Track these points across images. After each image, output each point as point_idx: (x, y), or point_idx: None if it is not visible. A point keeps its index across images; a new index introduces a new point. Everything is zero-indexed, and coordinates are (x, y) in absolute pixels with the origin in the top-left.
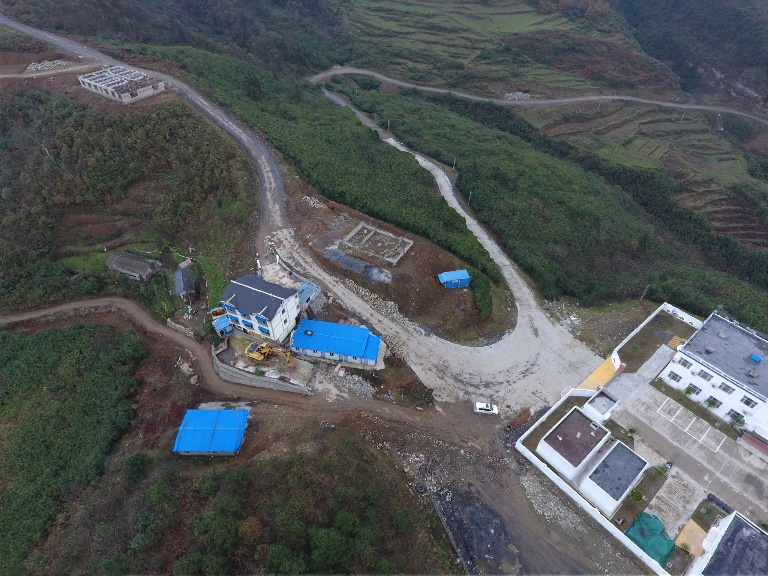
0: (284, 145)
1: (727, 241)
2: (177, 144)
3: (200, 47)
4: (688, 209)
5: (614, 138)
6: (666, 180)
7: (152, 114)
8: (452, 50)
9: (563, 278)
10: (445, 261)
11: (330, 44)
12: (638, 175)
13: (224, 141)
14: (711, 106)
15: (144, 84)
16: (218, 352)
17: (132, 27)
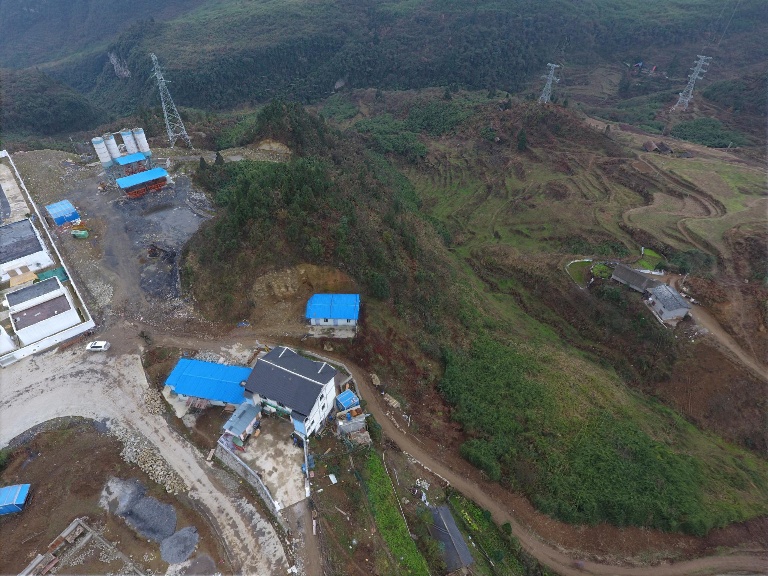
0: None
1: None
2: None
3: None
4: None
5: None
6: None
7: None
8: None
9: None
10: None
11: None
12: None
13: None
14: None
15: None
16: (349, 380)
17: None
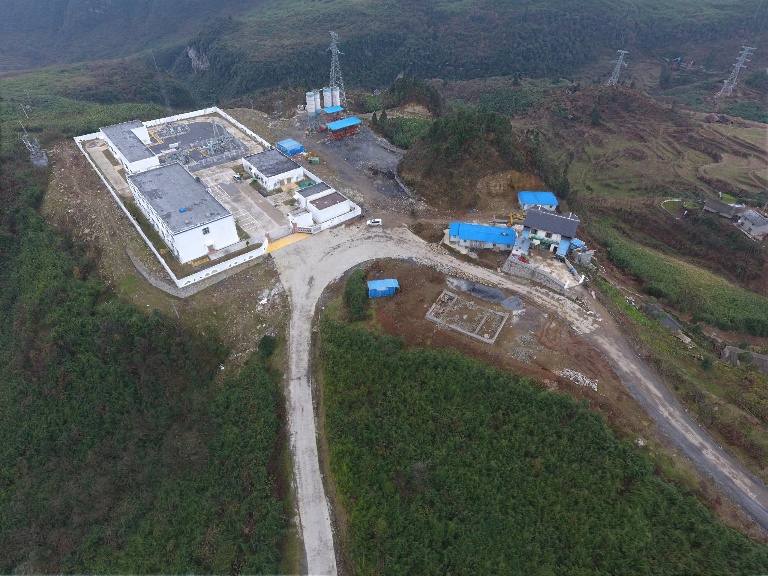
0: (746, 547)
1: None
2: None
3: None
4: None
5: None
6: None
7: None
8: None
9: None
10: None
11: None
12: None
13: None
14: None
15: None
16: None
17: None
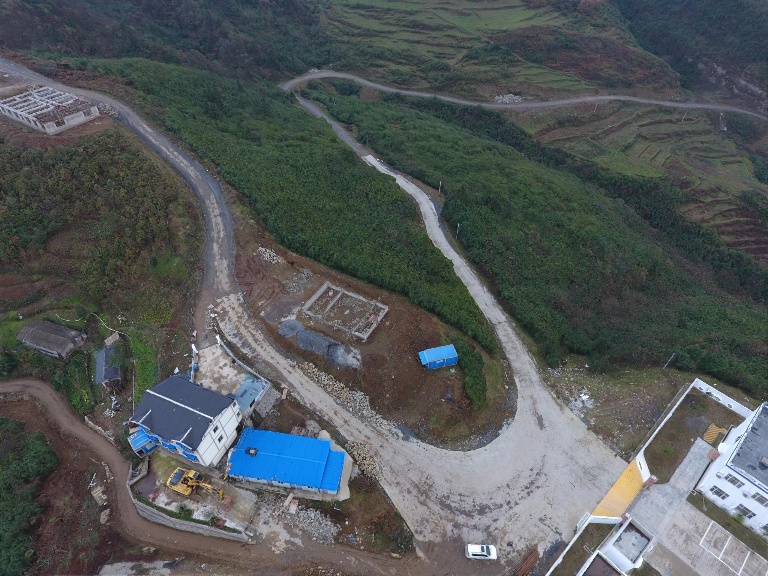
0: (238, 180)
1: (739, 258)
2: (107, 185)
3: (156, 56)
4: (696, 223)
5: (613, 143)
6: (671, 190)
7: (78, 148)
8: (437, 50)
9: (568, 332)
10: (428, 332)
11: (306, 45)
12: (640, 185)
13: (164, 180)
14: (713, 104)
15: (73, 110)
16: (134, 481)
17: (74, 37)
